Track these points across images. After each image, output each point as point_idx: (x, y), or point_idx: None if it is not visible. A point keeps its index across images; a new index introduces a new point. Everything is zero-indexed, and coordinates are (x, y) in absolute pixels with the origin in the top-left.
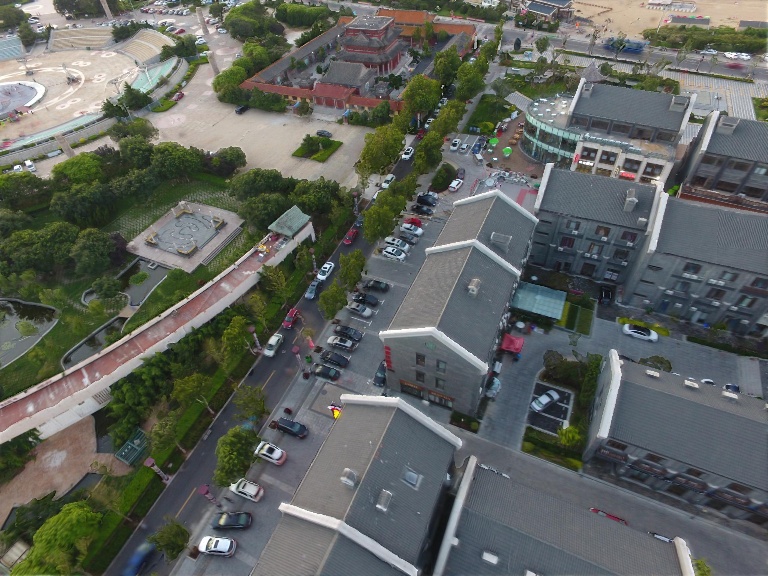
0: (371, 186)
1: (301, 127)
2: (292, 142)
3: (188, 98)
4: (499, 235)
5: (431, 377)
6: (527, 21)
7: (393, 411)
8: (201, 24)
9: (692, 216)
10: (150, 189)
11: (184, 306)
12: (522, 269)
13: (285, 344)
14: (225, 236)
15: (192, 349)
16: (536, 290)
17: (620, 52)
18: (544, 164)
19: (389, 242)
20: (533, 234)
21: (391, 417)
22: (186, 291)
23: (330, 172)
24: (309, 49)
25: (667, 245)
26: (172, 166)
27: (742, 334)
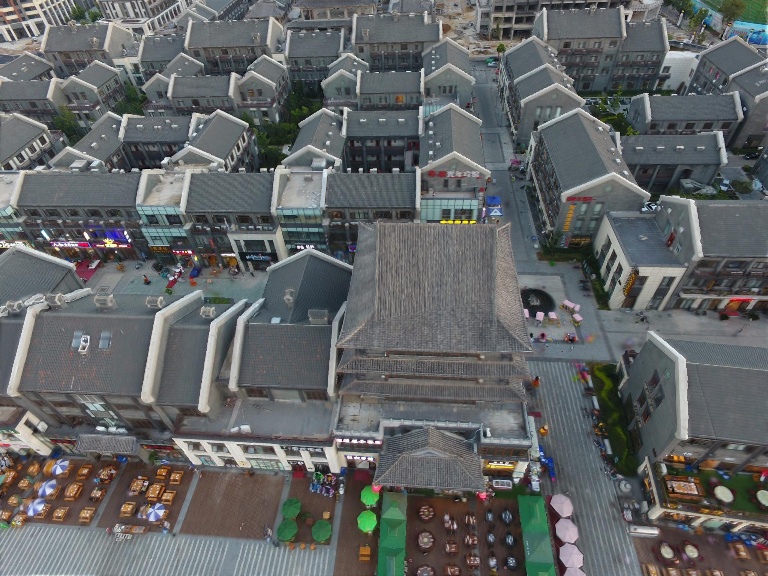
0: None
1: None
2: None
3: None
4: None
5: None
6: None
7: None
8: None
9: None
10: None
11: None
12: None
13: None
14: None
15: None
16: None
17: None
18: None
19: None
20: None
21: None
22: None
23: None
24: None
25: None
26: None
27: None
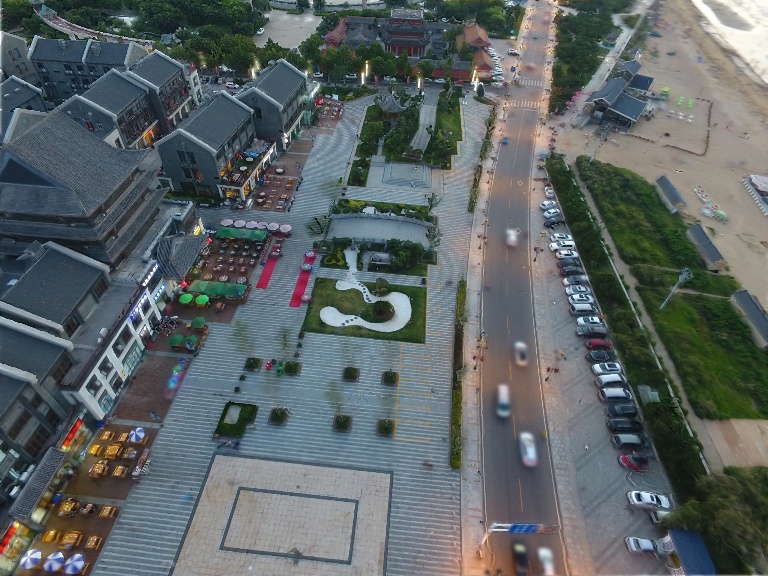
0: None
1: None
2: (284, 46)
3: None
4: (95, 44)
5: None
6: None
7: None
8: None
9: None
10: (211, 20)
11: None
12: None
13: None
14: None
15: None
16: None
17: None
18: None
19: None
20: None
21: None
22: None
23: None
24: None
25: None
26: (225, 16)
27: None
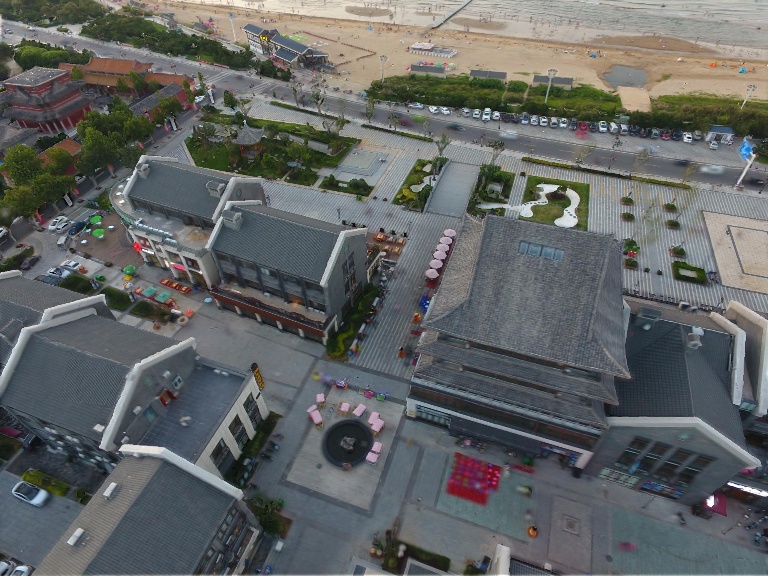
0: None
1: None
2: None
3: None
4: None
5: None
6: (264, 69)
7: None
8: None
9: (46, 358)
10: None
11: None
12: None
13: None
14: None
15: None
16: None
17: None
18: None
19: None
20: None
21: None
22: None
23: None
24: None
25: (12, 396)
26: None
27: None
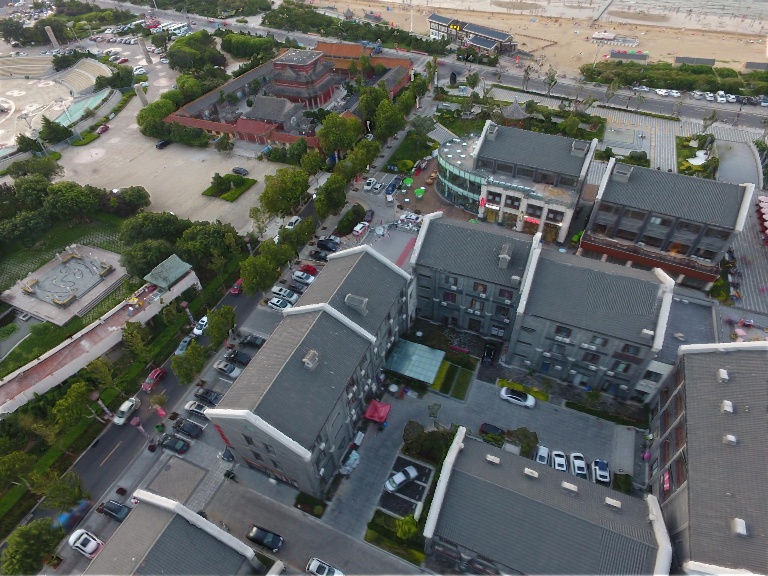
0: (275, 228)
1: (219, 163)
2: (206, 179)
3: (112, 131)
4: (353, 298)
5: (266, 458)
6: (468, 55)
7: (170, 518)
8: (144, 54)
9: (562, 276)
10: (38, 232)
11: (34, 367)
12: (404, 325)
13: (140, 410)
14: (109, 284)
15: (29, 419)
16: (414, 349)
17: (554, 88)
18: (456, 206)
19: (276, 292)
20: (416, 288)
21: (165, 526)
22: (52, 346)
23: (237, 213)
24: (242, 82)
25: (536, 307)
26: (65, 207)
27: (624, 399)
